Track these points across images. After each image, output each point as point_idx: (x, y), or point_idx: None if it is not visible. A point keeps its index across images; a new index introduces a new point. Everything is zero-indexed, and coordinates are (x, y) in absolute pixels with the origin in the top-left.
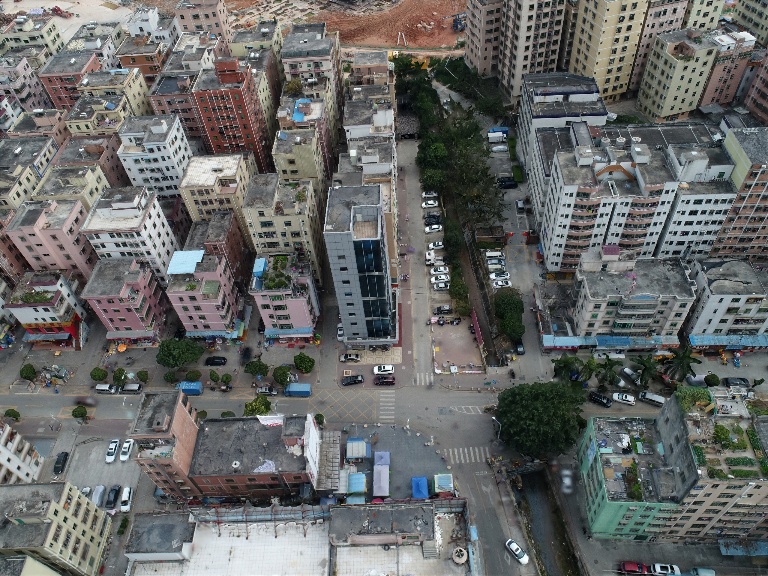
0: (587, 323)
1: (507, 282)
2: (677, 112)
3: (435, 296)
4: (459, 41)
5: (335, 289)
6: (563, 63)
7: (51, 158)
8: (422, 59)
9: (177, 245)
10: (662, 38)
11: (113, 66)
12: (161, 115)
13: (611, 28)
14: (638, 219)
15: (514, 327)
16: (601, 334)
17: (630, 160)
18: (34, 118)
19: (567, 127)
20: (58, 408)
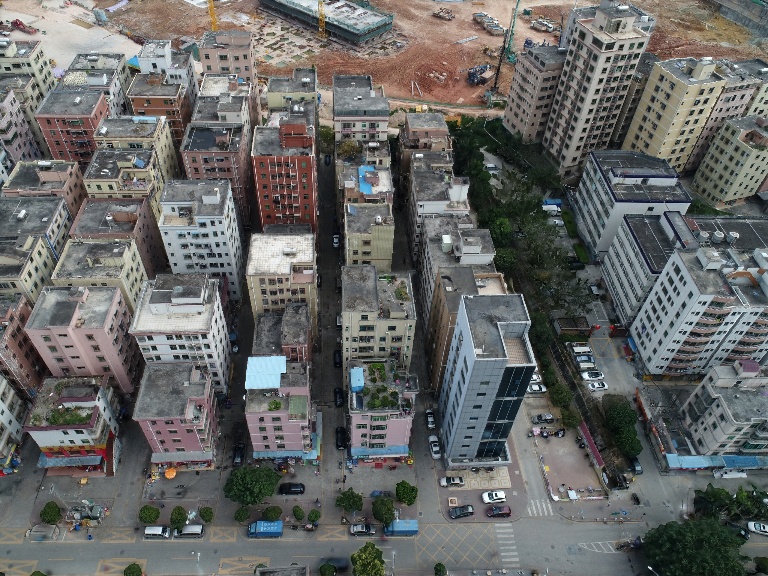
0: (719, 444)
1: (603, 384)
2: (738, 197)
3: (529, 400)
4: (492, 100)
5: (461, 414)
6: (616, 136)
7: (62, 223)
8: (456, 117)
9: (228, 337)
10: (733, 124)
11: (118, 105)
12: (209, 180)
13: (685, 110)
14: (762, 328)
15: (633, 444)
16: (727, 453)
17: (754, 265)
18: (39, 172)
19: (656, 215)
20: (95, 562)
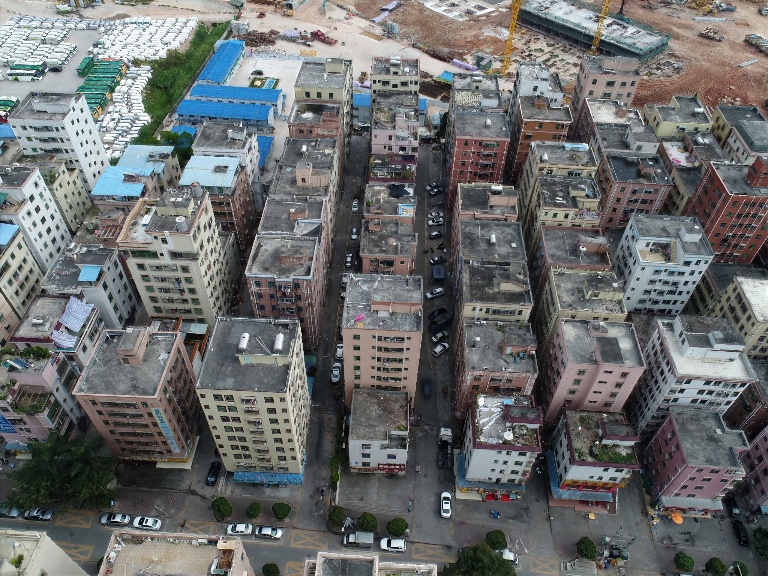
0: None
1: None
2: None
3: None
4: None
5: None
6: None
7: None
8: None
9: None
10: None
11: None
12: (676, 216)
13: None
14: None
15: None
16: None
17: None
18: (492, 196)
19: None
20: None
